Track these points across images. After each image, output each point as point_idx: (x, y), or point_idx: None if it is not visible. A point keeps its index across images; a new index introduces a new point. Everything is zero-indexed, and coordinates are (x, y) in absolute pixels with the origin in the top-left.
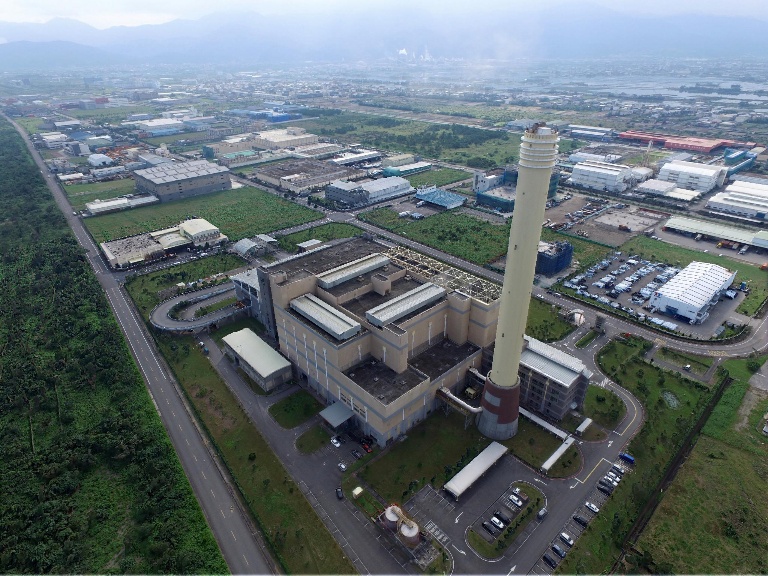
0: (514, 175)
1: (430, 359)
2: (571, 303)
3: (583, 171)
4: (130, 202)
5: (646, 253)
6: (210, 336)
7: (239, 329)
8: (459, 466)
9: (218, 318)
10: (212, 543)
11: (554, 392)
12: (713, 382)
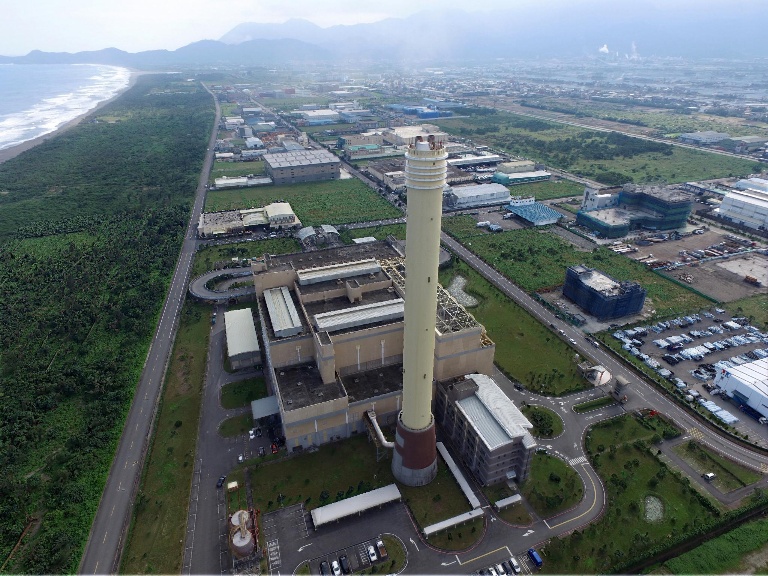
0: (631, 196)
1: (375, 378)
2: (607, 357)
3: (736, 202)
4: (248, 181)
5: (763, 317)
6: (226, 309)
7: (252, 308)
8: (339, 496)
9: (237, 294)
10: (99, 486)
11: (482, 451)
12: (735, 506)
